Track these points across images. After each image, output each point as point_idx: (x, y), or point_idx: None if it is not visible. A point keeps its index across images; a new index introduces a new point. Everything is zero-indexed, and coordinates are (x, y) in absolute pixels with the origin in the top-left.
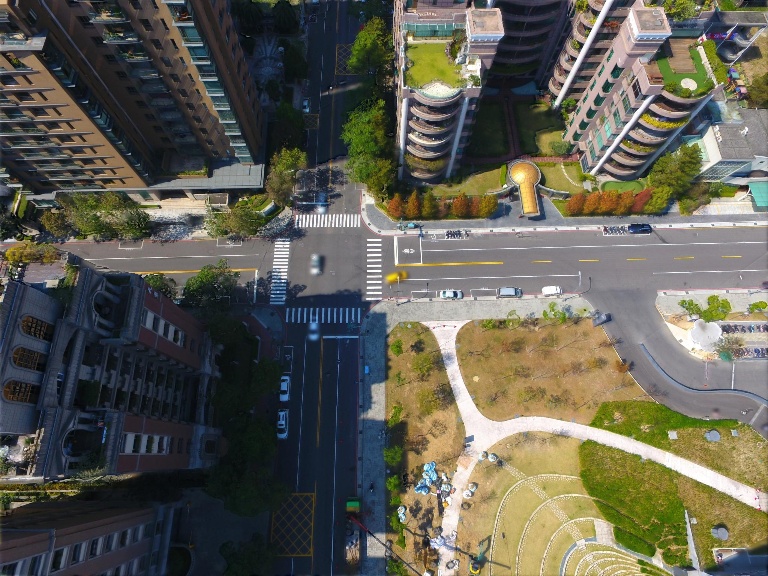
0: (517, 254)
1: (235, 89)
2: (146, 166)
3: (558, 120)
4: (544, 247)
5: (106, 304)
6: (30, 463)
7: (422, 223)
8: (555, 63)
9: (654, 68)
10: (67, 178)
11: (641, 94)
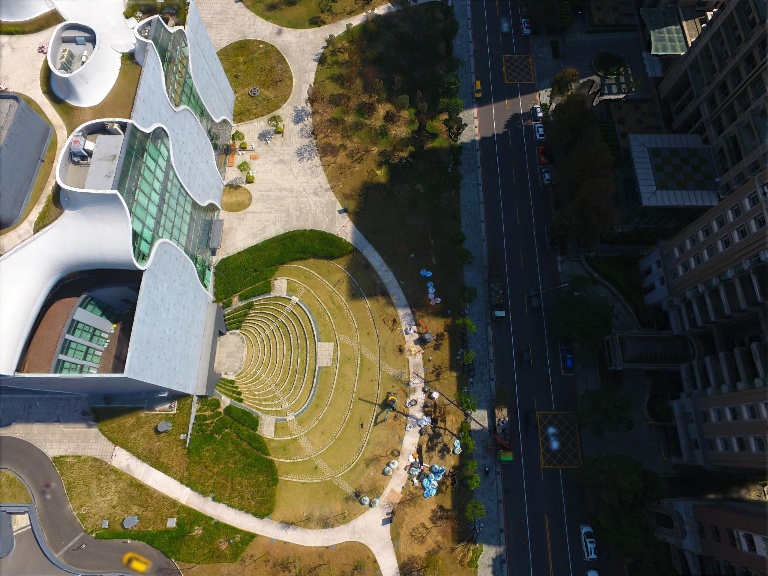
0: None
1: None
2: None
3: None
4: None
5: None
6: None
7: None
8: None
9: None
10: None
11: None
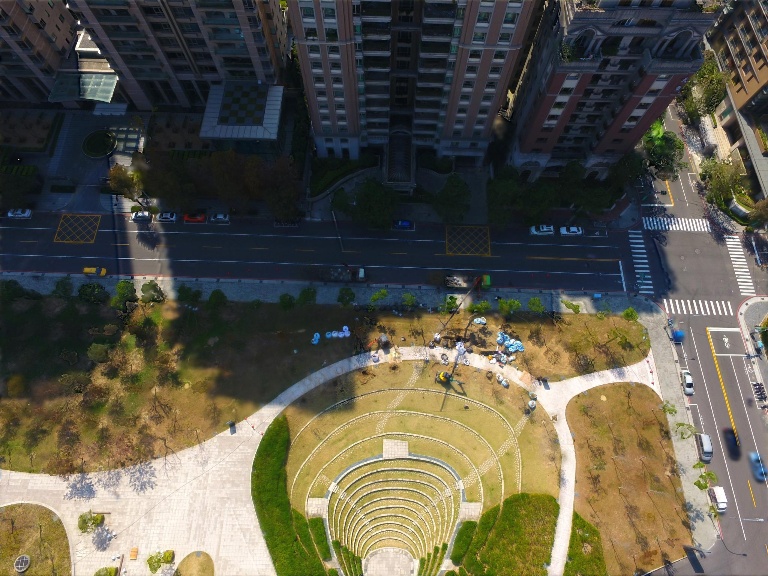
0: (754, 464)
1: None
2: (762, 102)
3: None
4: None
5: (674, 49)
6: (583, 8)
7: (764, 358)
8: None
9: None
10: (733, 51)
11: None
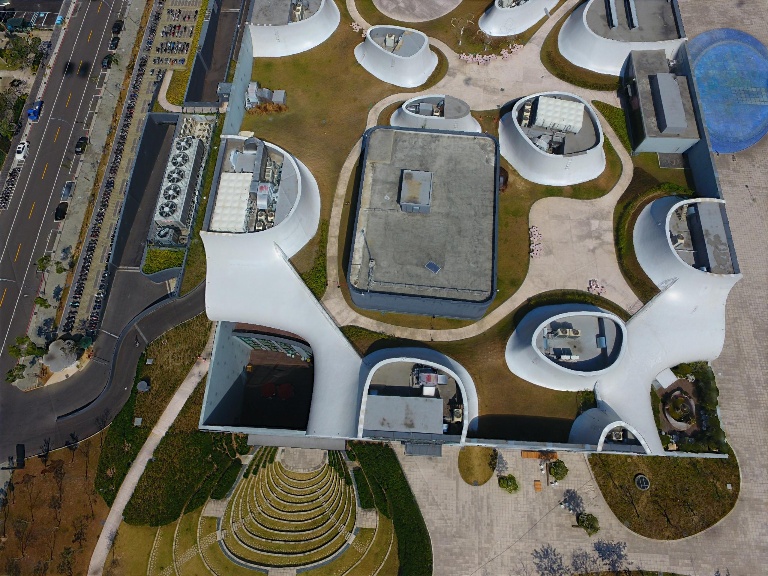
0: None
1: None
2: None
3: None
4: None
5: None
6: None
7: None
8: None
9: None
10: None
11: None
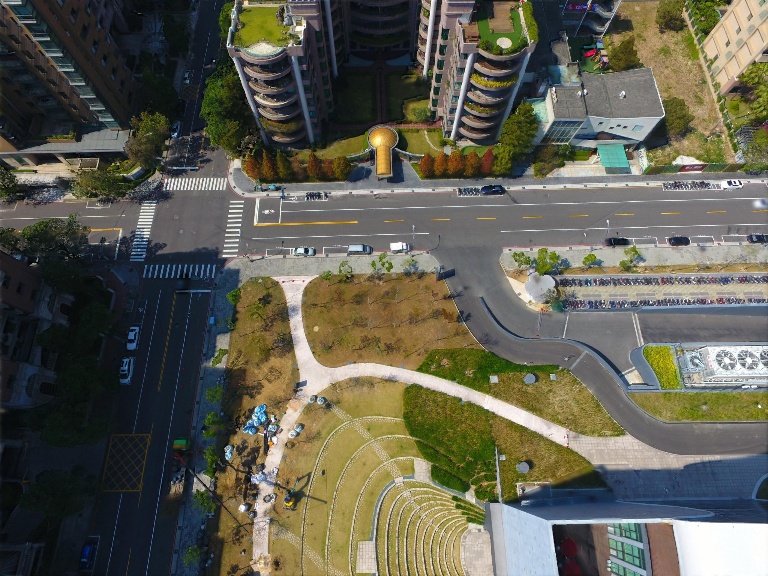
0: (372, 214)
1: (81, 52)
2: (13, 130)
3: (427, 89)
4: (399, 207)
5: None
6: None
7: (285, 186)
8: (419, 33)
9: (473, 28)
10: None
11: (461, 53)
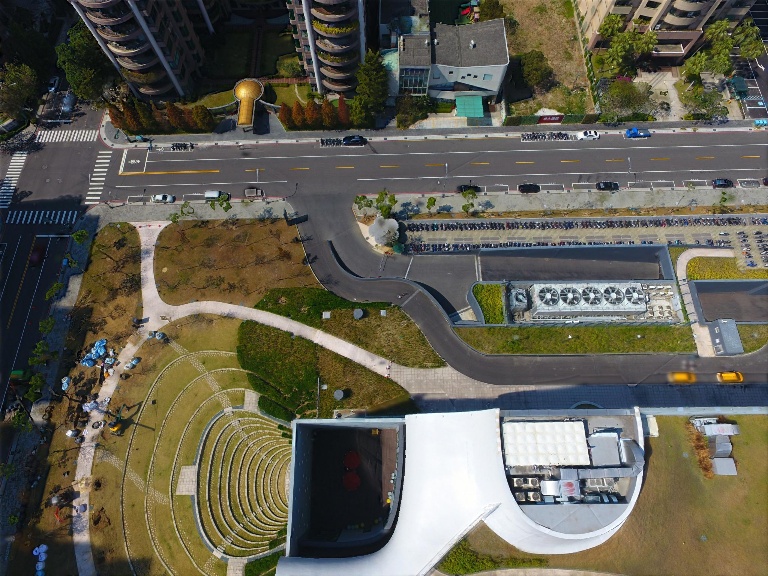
0: (234, 164)
1: None
2: None
3: None
4: (261, 157)
5: None
6: None
7: (153, 137)
8: None
9: None
10: None
11: None
